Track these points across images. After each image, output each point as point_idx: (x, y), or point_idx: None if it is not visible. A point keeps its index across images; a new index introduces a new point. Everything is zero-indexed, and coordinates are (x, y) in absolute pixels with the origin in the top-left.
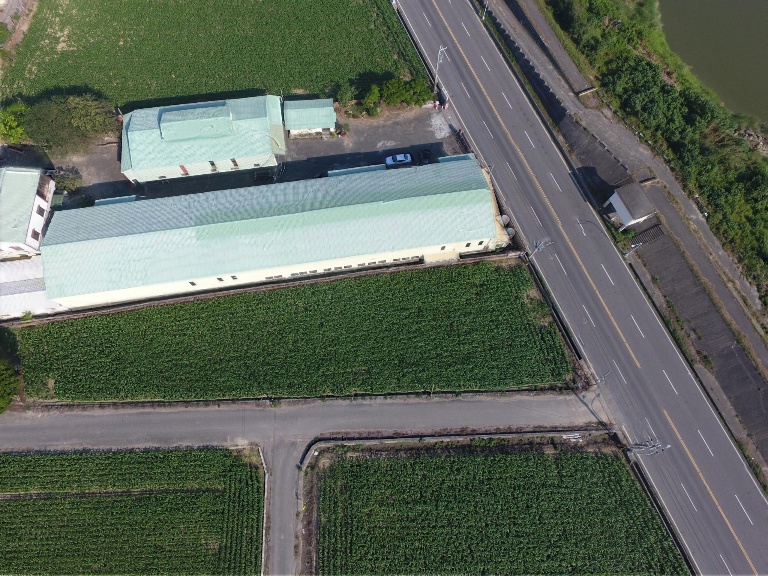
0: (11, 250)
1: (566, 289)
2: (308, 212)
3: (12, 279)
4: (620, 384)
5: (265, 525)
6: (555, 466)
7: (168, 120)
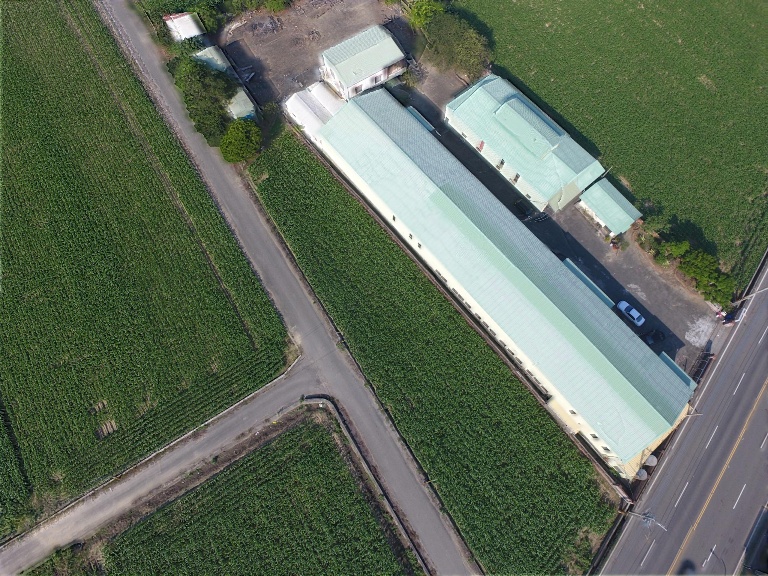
0: (338, 83)
1: (625, 574)
2: (516, 267)
3: (320, 99)
4: None
5: (247, 399)
6: None
7: (513, 106)
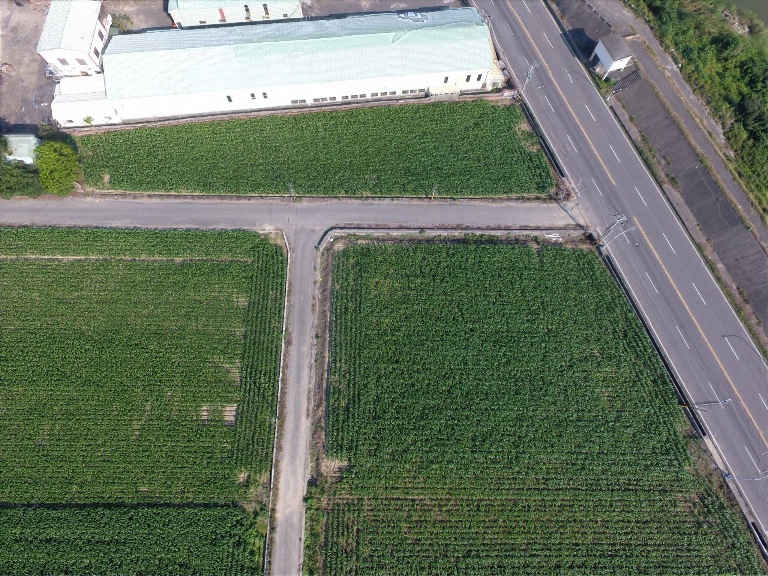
0: (76, 65)
1: (553, 123)
2: (330, 38)
3: (75, 91)
4: (597, 196)
5: (287, 289)
6: (537, 255)
7: None
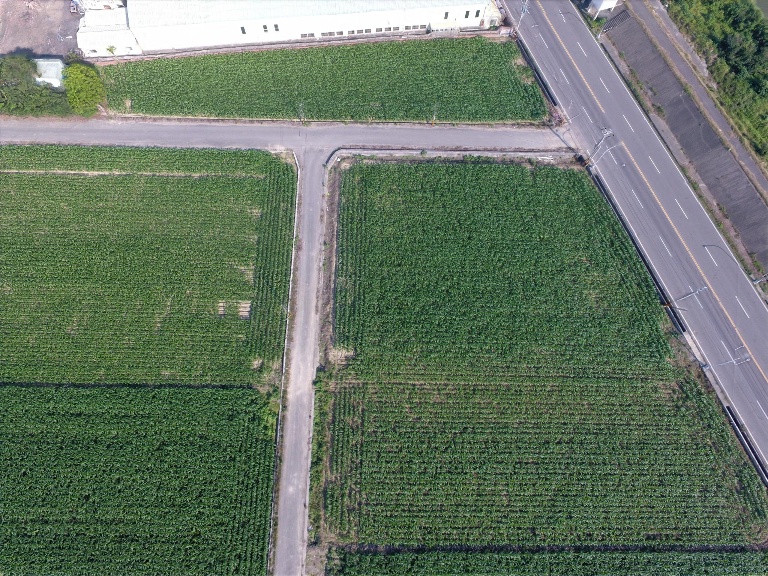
0: None
1: (547, 58)
2: None
3: (99, 23)
4: (587, 123)
5: (297, 202)
6: (530, 174)
7: None
